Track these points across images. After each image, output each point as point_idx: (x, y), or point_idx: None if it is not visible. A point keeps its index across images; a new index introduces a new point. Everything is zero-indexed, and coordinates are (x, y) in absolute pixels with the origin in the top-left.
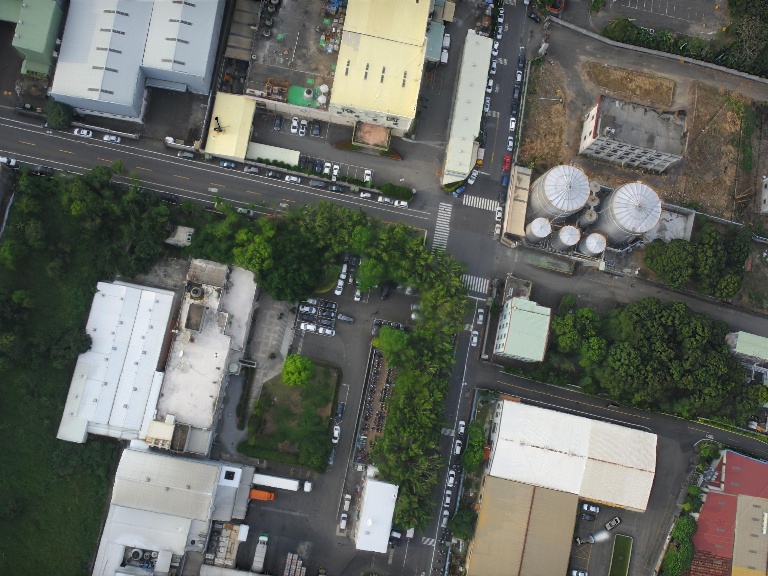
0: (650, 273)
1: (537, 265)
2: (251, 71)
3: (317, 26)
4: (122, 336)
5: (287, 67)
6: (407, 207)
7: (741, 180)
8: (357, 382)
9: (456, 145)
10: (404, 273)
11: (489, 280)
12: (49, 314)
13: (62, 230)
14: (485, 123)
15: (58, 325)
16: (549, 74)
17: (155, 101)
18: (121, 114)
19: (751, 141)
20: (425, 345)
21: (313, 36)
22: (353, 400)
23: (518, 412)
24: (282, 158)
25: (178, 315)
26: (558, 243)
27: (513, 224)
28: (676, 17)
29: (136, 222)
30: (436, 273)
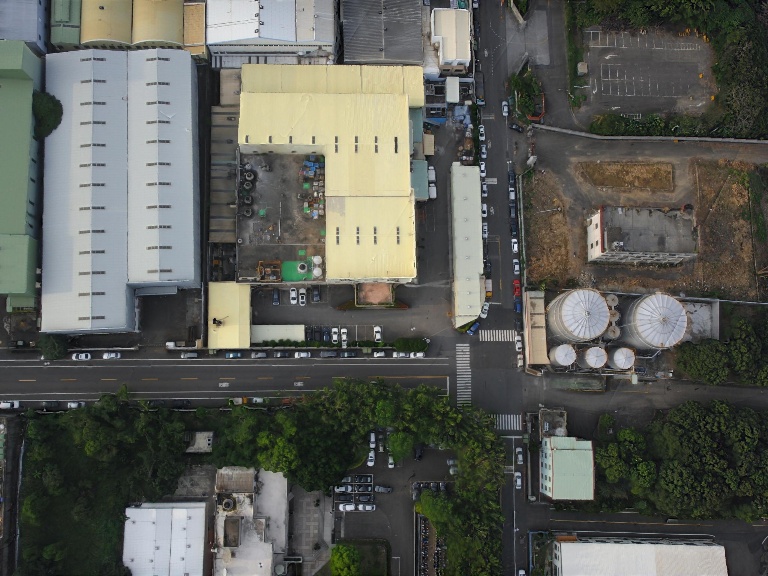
0: (684, 373)
1: (567, 389)
2: (239, 255)
3: (298, 193)
4: (161, 562)
5: (275, 243)
6: (424, 357)
7: (759, 252)
8: (407, 552)
9: (463, 287)
10: (436, 440)
11: (521, 415)
12: (83, 556)
13: (79, 465)
14: (487, 251)
15: (94, 565)
16: (542, 184)
17: (148, 306)
18: (116, 331)
19: (761, 207)
20: (470, 506)
21: (295, 205)
22: (407, 572)
23: (577, 553)
24: (287, 335)
25: (214, 532)
26: (585, 365)
27: (535, 354)
28: (661, 95)
29: (153, 443)
30: (468, 430)
